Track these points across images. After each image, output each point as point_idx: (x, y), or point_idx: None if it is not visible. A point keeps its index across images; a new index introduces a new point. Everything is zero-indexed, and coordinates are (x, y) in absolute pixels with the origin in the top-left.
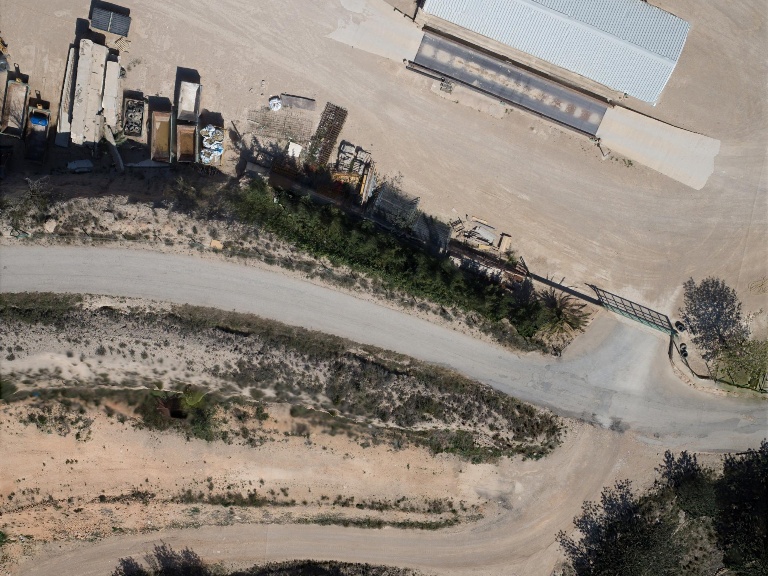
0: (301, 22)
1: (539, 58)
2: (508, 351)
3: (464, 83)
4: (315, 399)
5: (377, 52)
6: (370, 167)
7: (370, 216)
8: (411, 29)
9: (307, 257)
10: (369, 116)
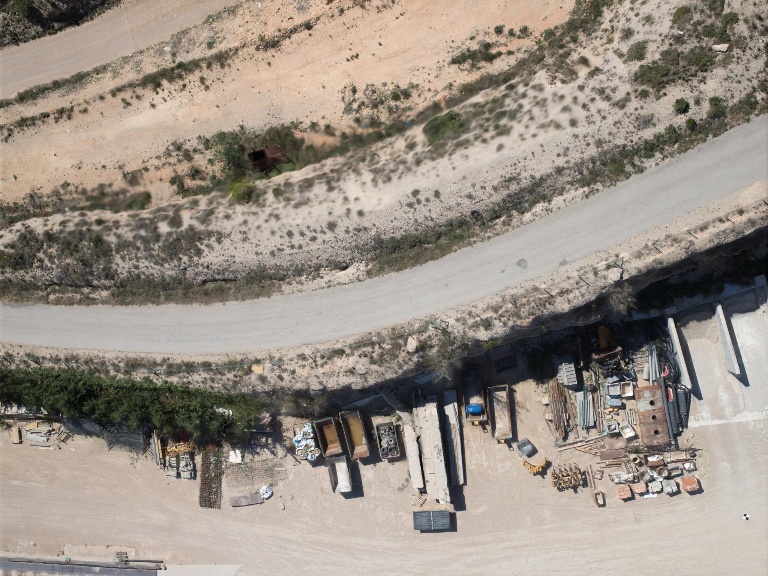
0: (267, 570)
1: None
2: None
3: (107, 567)
4: (118, 235)
5: (192, 567)
6: None
7: None
8: None
9: (174, 380)
10: (180, 508)
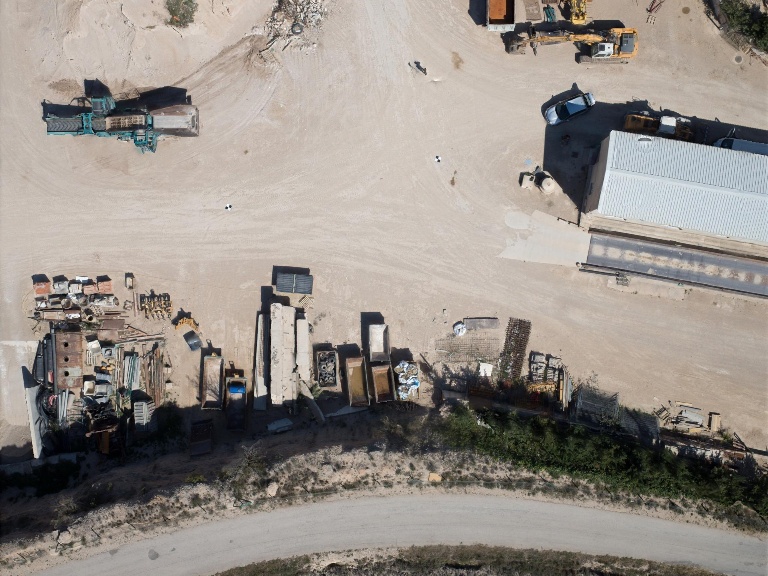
0: (471, 248)
1: (707, 236)
2: (747, 535)
3: (640, 273)
4: None
5: (549, 261)
6: (564, 372)
7: (575, 420)
8: (578, 234)
9: (526, 473)
10: (552, 323)
